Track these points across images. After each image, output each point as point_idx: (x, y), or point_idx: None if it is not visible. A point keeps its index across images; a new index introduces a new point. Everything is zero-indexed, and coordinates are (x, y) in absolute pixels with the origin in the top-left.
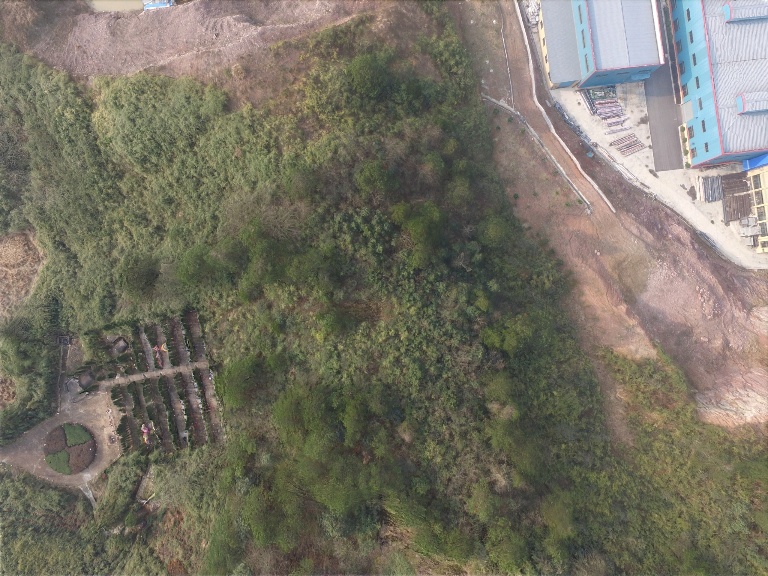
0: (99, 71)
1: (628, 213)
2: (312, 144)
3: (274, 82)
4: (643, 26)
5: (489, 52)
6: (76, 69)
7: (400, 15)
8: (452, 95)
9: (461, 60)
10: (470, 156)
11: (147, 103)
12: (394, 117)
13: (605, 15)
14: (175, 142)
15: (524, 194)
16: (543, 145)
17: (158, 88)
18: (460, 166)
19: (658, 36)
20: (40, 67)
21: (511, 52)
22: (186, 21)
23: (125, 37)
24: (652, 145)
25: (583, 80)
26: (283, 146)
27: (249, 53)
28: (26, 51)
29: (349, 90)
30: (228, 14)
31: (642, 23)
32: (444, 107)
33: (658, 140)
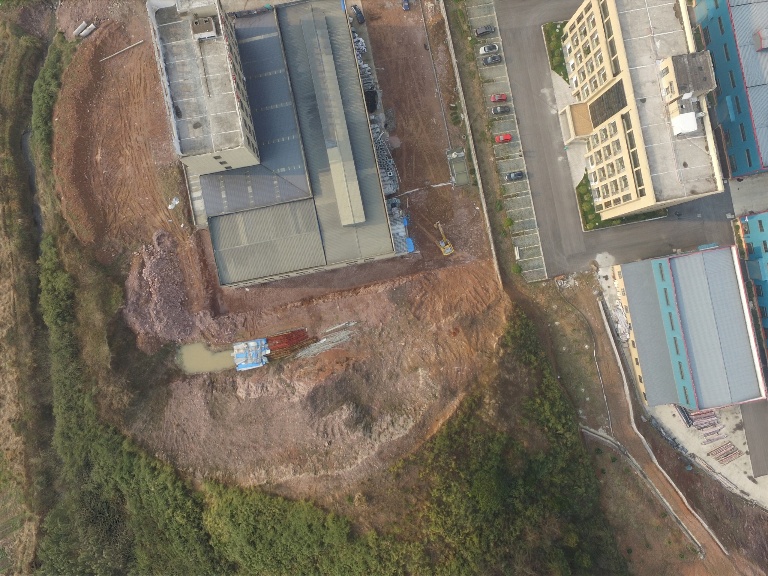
0: (204, 462)
1: (739, 549)
2: (440, 570)
3: (397, 506)
4: (742, 359)
5: (584, 379)
6: (179, 455)
7: (505, 386)
8: (561, 461)
9: (566, 419)
10: (583, 520)
11: (266, 524)
12: (513, 512)
13: (704, 352)
14: (296, 558)
15: (636, 543)
16: (646, 477)
17: (277, 511)
18: (585, 565)
19: (758, 369)
20: (143, 460)
21: (605, 377)
22: (293, 419)
23: (226, 421)
24: (749, 451)
25: (681, 405)
26: (411, 572)
27: (369, 477)
28: (123, 430)
29: (473, 510)
30: (334, 405)
31: (741, 356)
32: (555, 478)
33: (754, 445)
